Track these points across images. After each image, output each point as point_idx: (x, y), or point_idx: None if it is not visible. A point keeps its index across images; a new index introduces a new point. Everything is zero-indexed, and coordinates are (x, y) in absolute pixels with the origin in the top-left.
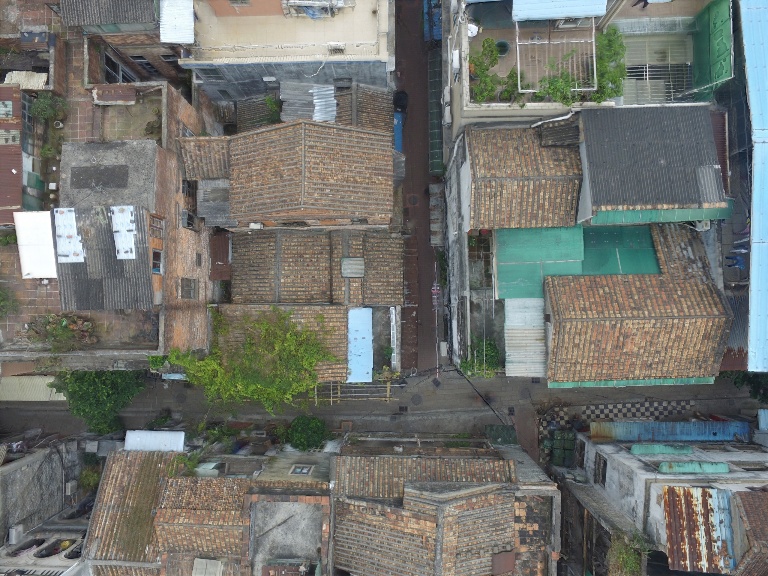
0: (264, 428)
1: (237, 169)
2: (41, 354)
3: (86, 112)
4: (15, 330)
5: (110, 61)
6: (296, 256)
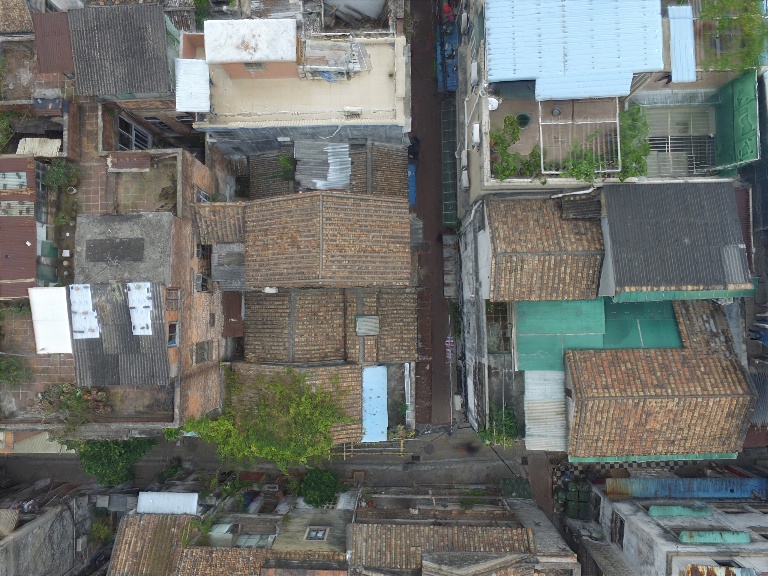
0: (276, 480)
1: (253, 236)
2: (55, 426)
3: (100, 177)
4: (28, 398)
5: (123, 121)
6: (310, 314)
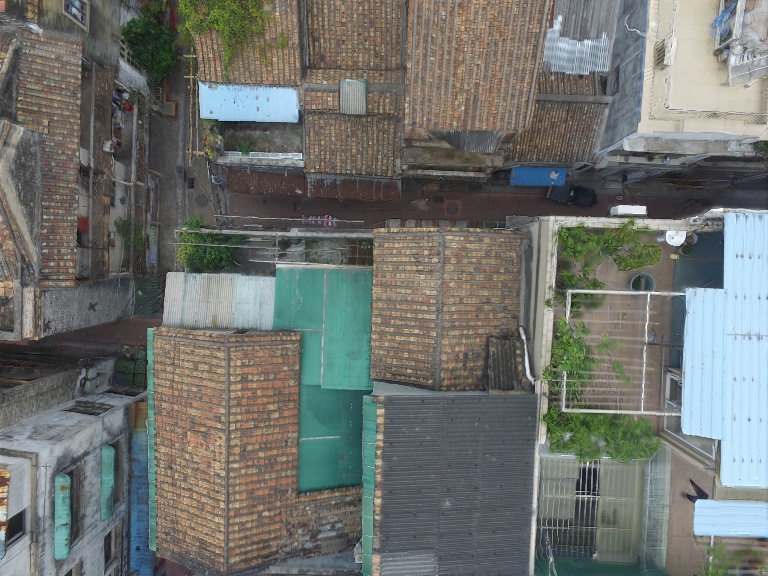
0: None
1: None
2: None
3: None
4: None
5: None
6: (372, 16)
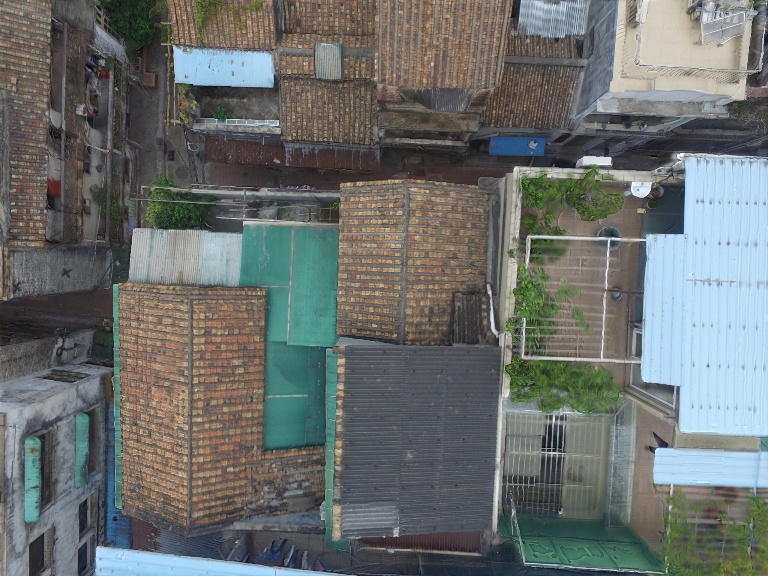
0: None
1: None
2: None
3: None
4: None
5: None
6: None
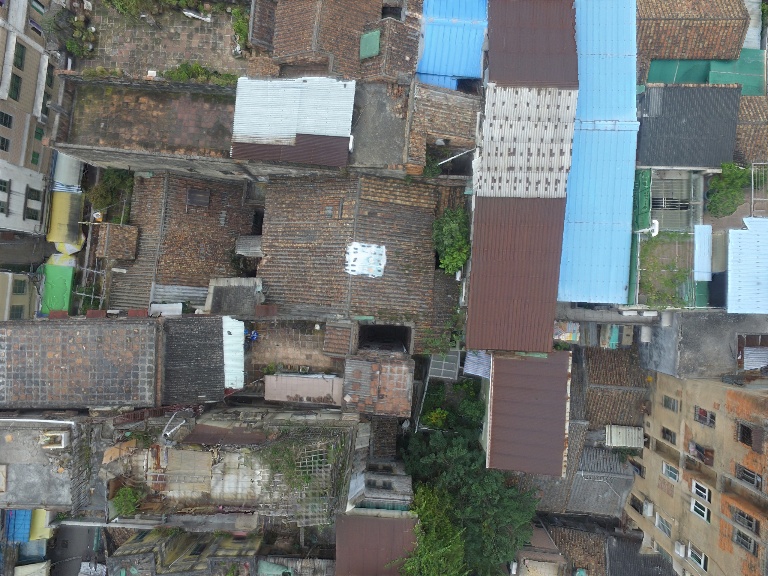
0: None
1: None
2: None
3: None
4: None
5: None
6: None
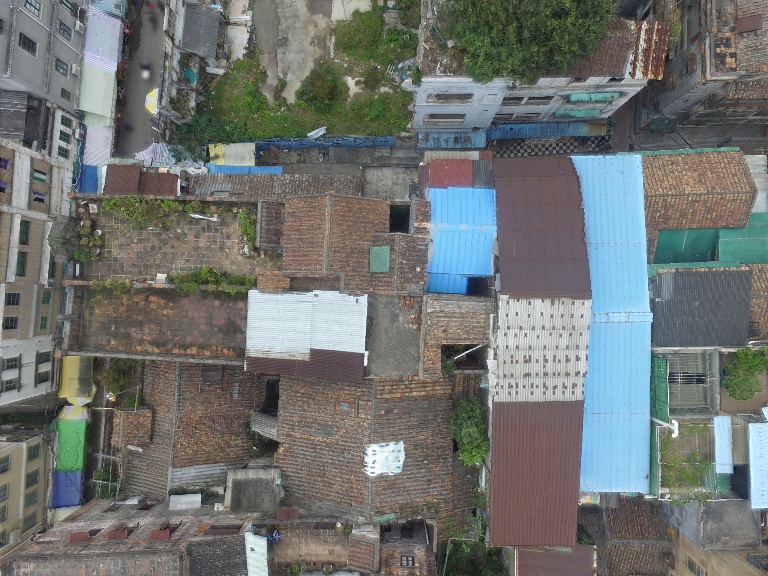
0: None
1: None
2: None
3: None
4: None
5: None
6: None
